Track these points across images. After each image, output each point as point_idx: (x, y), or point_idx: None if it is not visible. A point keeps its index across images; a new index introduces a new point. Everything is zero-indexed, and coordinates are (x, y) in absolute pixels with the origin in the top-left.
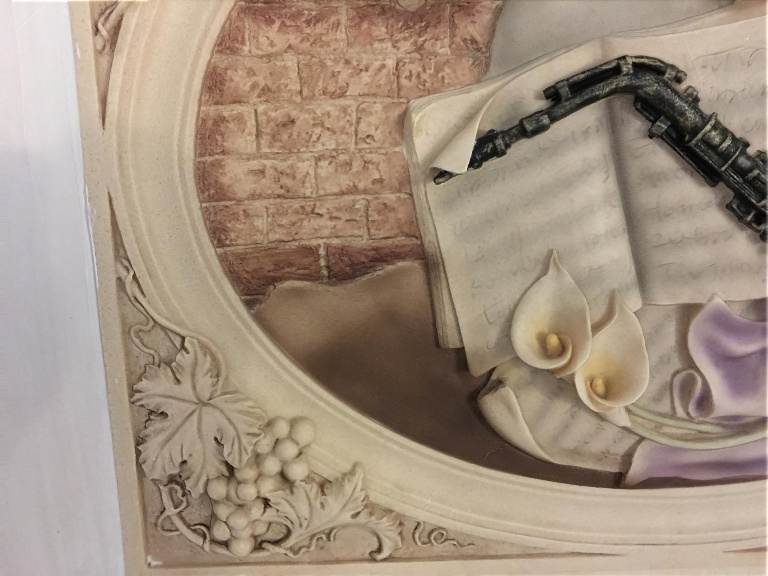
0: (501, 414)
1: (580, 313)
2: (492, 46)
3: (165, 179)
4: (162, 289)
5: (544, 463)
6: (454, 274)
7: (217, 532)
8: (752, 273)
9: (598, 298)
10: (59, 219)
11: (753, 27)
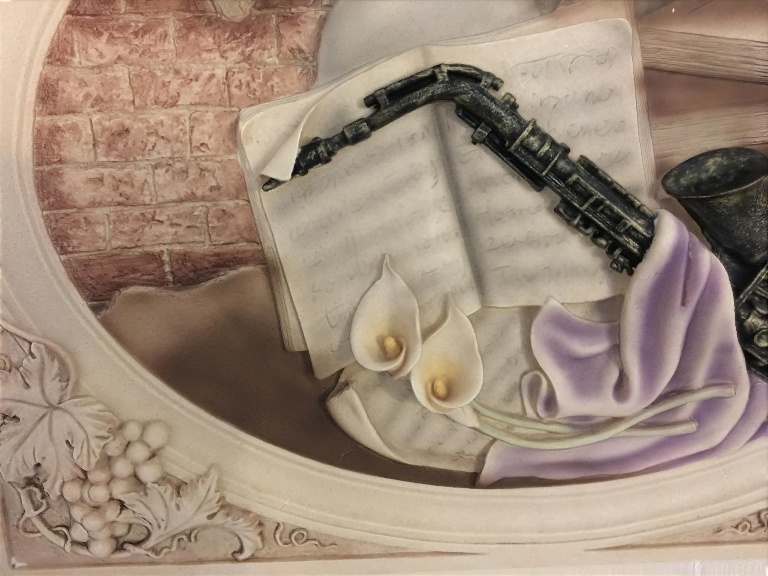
0: (347, 416)
1: (411, 316)
2: (318, 55)
3: (6, 188)
4: (8, 295)
5: (397, 464)
6: (294, 279)
7: (74, 533)
8: (588, 275)
9: (433, 301)
10: None
11: (571, 34)
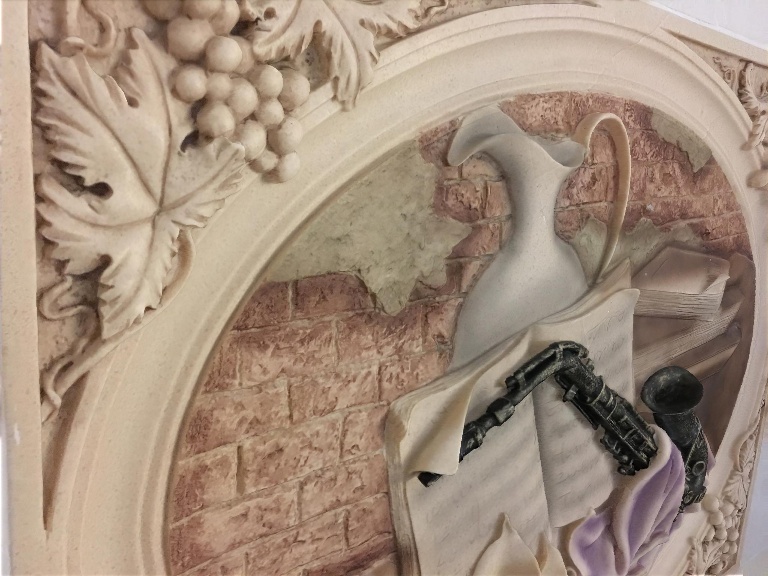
0: None
1: (530, 567)
2: (455, 339)
3: (120, 561)
4: None
5: None
6: (425, 560)
7: None
8: (606, 482)
9: (532, 543)
10: None
11: (611, 303)
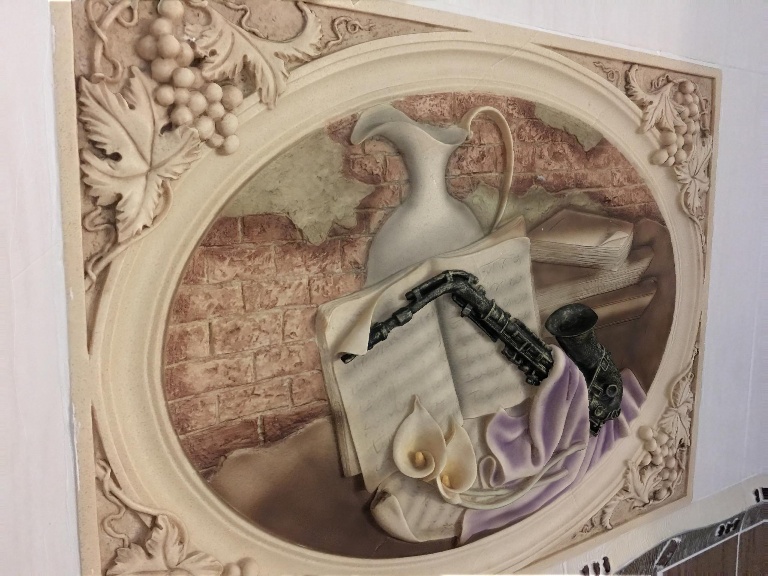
0: (389, 516)
1: (437, 435)
2: (367, 265)
3: (135, 386)
4: (135, 479)
5: (413, 544)
6: (353, 422)
7: None
8: (515, 389)
9: (442, 422)
10: (43, 437)
11: (503, 247)
